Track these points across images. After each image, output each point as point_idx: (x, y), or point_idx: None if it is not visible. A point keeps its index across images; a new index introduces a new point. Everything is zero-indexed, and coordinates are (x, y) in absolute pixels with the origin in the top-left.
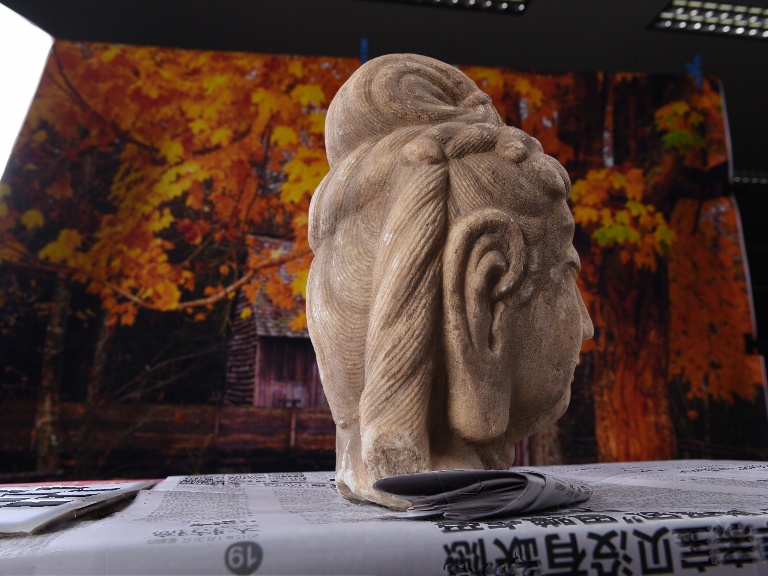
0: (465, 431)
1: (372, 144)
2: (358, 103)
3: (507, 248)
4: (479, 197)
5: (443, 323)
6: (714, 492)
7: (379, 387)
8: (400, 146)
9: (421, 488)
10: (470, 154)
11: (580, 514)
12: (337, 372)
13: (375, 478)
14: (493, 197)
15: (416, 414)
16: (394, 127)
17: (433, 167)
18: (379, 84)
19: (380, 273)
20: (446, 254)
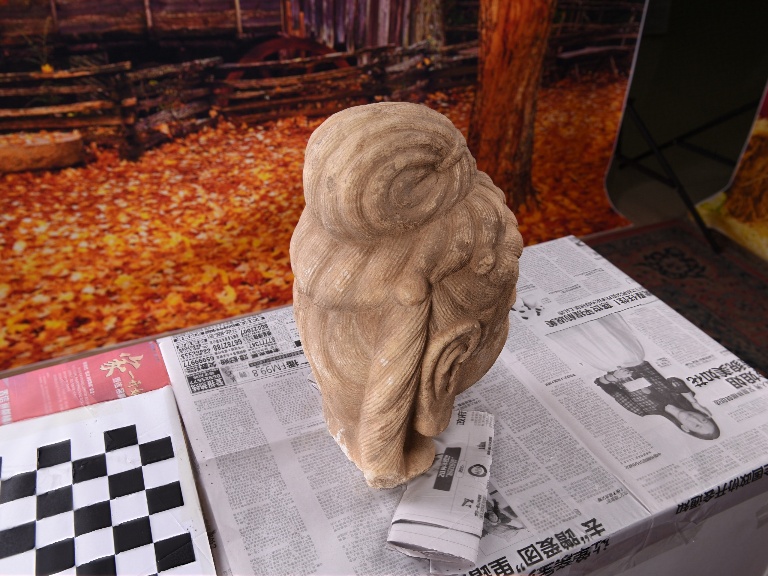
0: (425, 435)
1: (364, 258)
2: (350, 217)
3: (468, 340)
4: (454, 316)
5: (418, 395)
6: (565, 432)
7: (376, 444)
8: (393, 281)
9: (416, 548)
10: (450, 275)
11: (494, 538)
12: (336, 403)
13: (373, 485)
14: (464, 309)
15: (399, 454)
16: (383, 237)
17: (421, 307)
18: (371, 202)
19: (376, 378)
20: (425, 361)
